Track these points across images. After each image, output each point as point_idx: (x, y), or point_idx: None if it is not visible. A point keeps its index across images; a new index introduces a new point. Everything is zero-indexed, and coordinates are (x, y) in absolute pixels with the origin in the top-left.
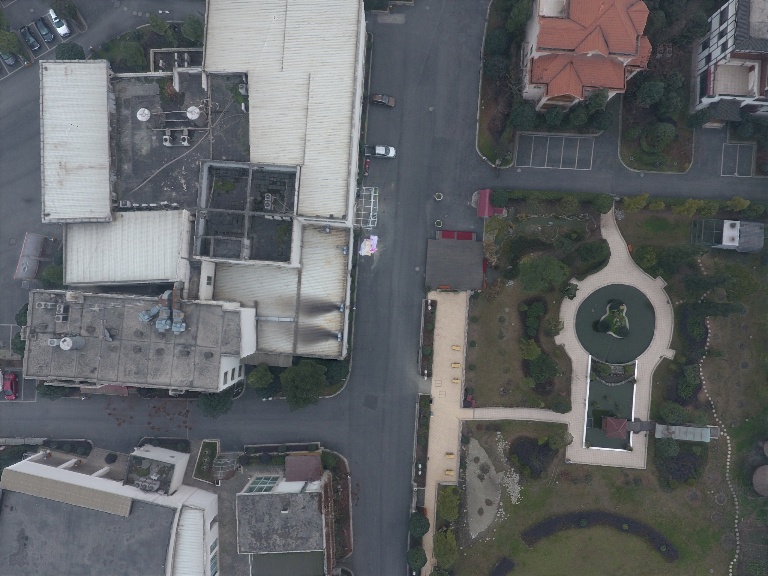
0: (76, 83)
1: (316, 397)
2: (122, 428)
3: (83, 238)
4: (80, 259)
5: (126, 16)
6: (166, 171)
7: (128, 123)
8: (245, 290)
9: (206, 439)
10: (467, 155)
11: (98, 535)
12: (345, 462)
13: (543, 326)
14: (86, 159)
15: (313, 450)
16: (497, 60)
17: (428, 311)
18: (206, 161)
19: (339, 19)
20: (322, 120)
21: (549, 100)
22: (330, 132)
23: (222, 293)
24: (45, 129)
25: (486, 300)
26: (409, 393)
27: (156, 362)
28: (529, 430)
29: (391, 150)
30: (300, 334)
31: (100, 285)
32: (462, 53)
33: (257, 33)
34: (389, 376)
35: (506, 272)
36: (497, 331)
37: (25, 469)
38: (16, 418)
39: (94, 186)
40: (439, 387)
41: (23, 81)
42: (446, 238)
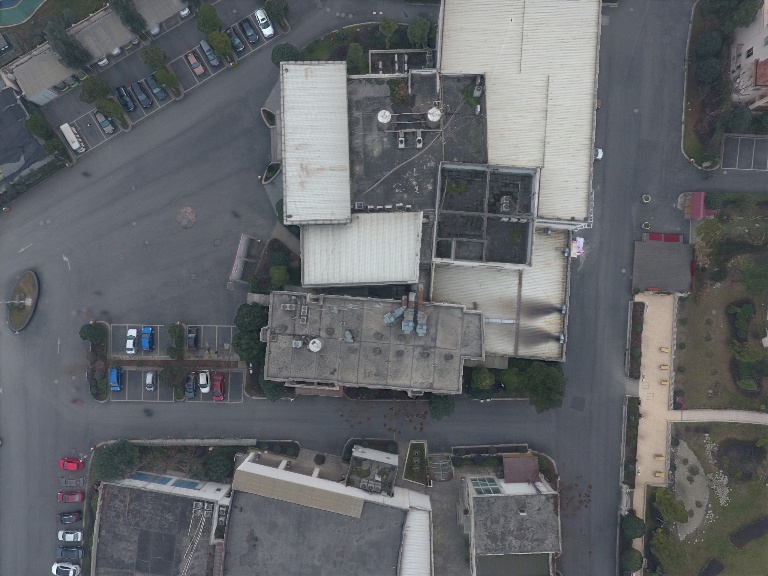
0: (316, 85)
1: (561, 399)
2: (329, 429)
3: (319, 240)
4: (317, 261)
5: (329, 17)
6: (398, 173)
7: (359, 125)
8: (463, 292)
9: (413, 440)
10: (673, 157)
11: (328, 536)
12: (553, 464)
13: (751, 328)
14: (327, 161)
15: (524, 452)
16: (714, 62)
17: (637, 313)
18: (446, 163)
19: (579, 21)
20: (562, 122)
21: (765, 102)
22: (570, 134)
23: (439, 295)
24: (286, 131)
25: (693, 302)
26: (616, 395)
27: (396, 364)
28: (737, 432)
29: (599, 152)
30: (521, 336)
31: (333, 287)
32: (667, 55)
33: (494, 35)
34: (596, 378)
35: (714, 274)
36: (704, 333)
37: (254, 470)
38: (223, 419)
39: (335, 188)
40: (647, 389)
41: (226, 82)
42: (653, 240)
